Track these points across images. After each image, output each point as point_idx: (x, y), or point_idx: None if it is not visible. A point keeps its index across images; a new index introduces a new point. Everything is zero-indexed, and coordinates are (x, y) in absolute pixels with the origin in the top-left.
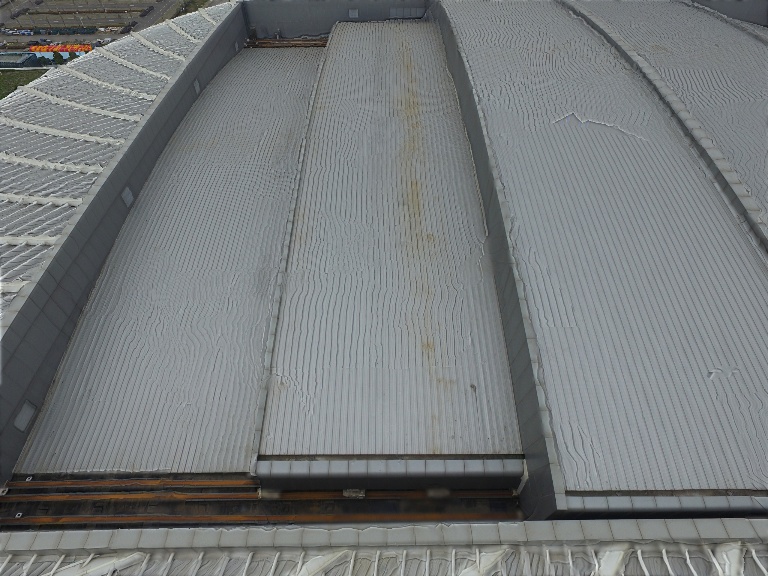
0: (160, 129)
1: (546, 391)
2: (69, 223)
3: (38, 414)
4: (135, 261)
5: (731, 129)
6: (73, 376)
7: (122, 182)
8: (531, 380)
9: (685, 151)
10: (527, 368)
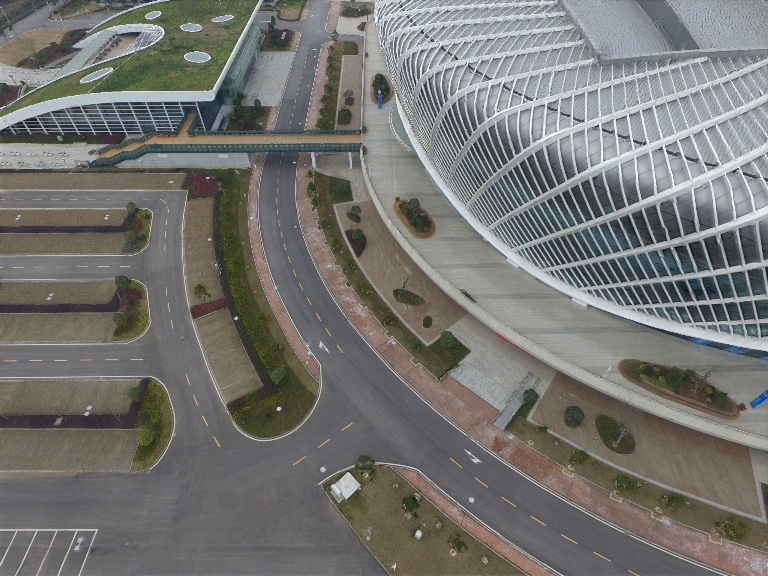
0: None
1: None
2: None
3: None
4: None
5: None
6: None
7: None
8: None
9: None
10: None
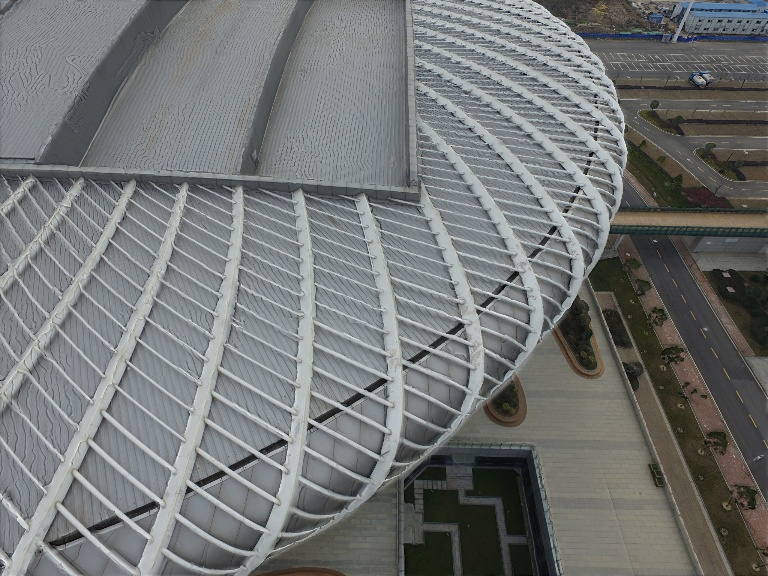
0: None
1: None
2: None
3: None
4: None
5: None
6: None
7: None
8: None
9: None
10: None
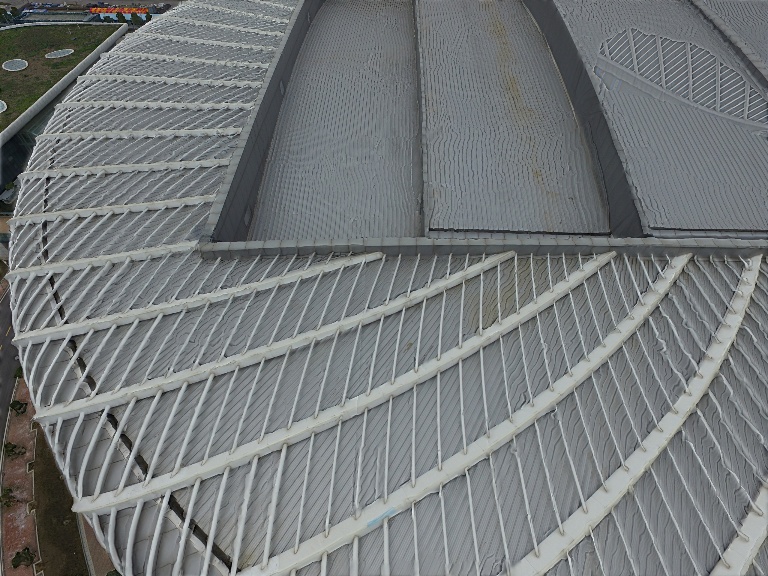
0: (294, 44)
1: (632, 179)
2: (259, 93)
3: (252, 219)
4: (296, 132)
5: (759, 41)
6: (270, 199)
7: (280, 75)
8: (622, 172)
9: (724, 51)
10: (619, 166)
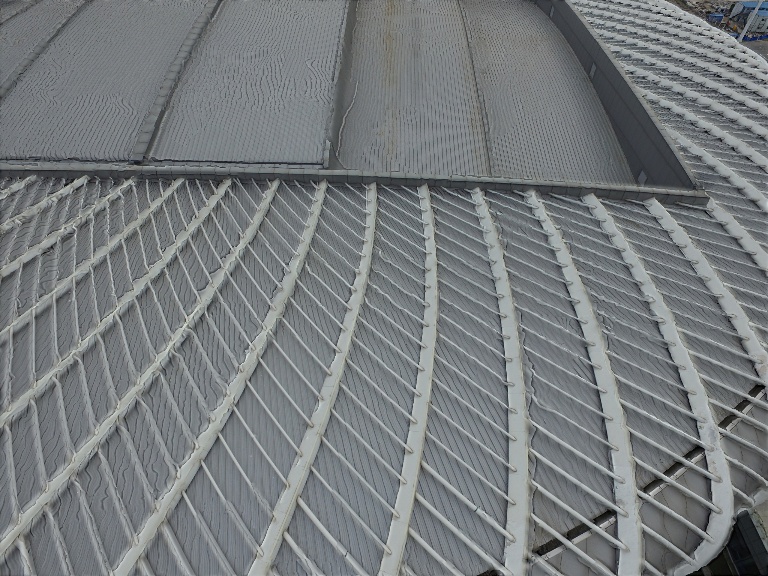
0: None
1: None
2: None
3: None
4: None
5: None
6: None
7: (554, 2)
8: None
9: None
10: None
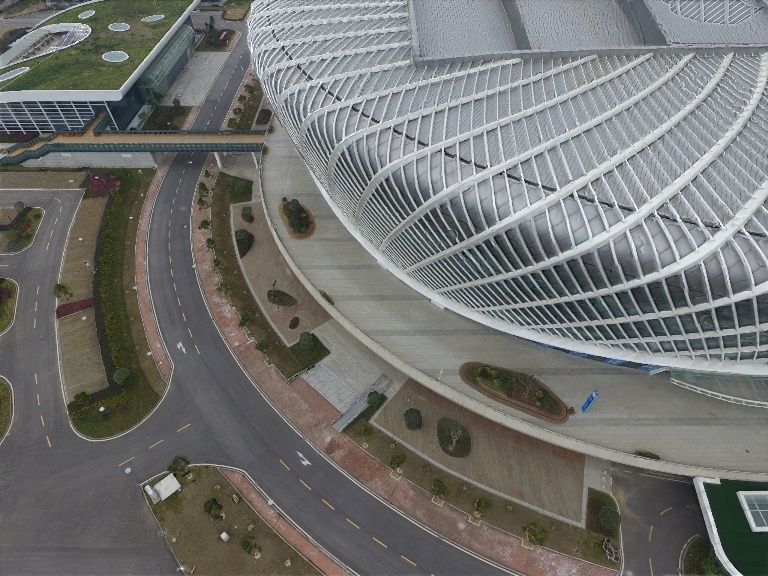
0: None
1: None
2: None
3: None
4: (426, 25)
5: None
6: None
7: None
8: (652, 19)
9: None
10: (650, 15)
